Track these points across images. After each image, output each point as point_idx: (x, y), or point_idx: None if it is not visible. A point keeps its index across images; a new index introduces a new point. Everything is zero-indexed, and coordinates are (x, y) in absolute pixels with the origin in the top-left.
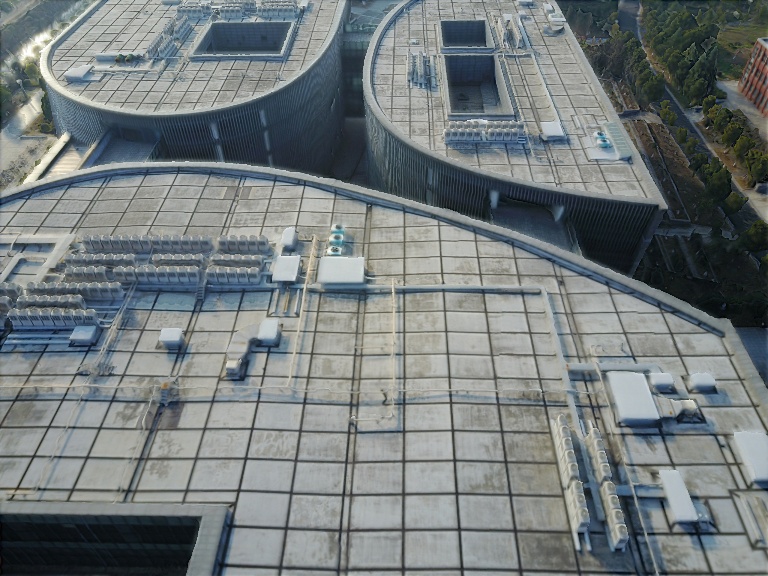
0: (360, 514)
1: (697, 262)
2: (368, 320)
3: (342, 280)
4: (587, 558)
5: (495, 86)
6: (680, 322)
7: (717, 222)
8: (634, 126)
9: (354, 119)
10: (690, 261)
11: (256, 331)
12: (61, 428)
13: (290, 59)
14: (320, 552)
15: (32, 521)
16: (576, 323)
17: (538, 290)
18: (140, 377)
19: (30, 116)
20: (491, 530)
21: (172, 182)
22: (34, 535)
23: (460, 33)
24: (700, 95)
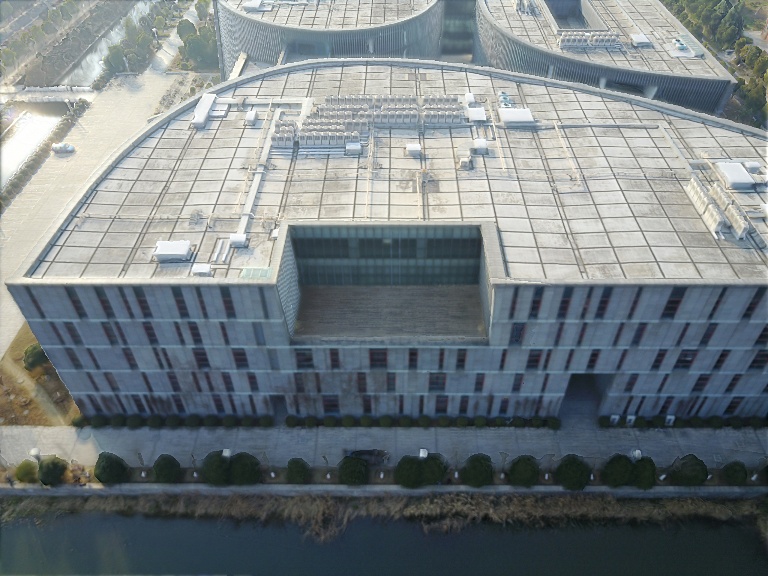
0: (576, 227)
1: None
2: (543, 142)
3: (519, 120)
4: (723, 242)
5: (580, 18)
6: (758, 141)
7: (758, 122)
8: None
9: (448, 57)
10: None
11: (472, 145)
12: (364, 192)
13: None
14: (558, 241)
15: (365, 236)
16: (687, 143)
17: (656, 126)
18: (402, 169)
19: (167, 58)
20: (661, 231)
21: (365, 70)
22: (357, 253)
23: None
24: (731, 40)
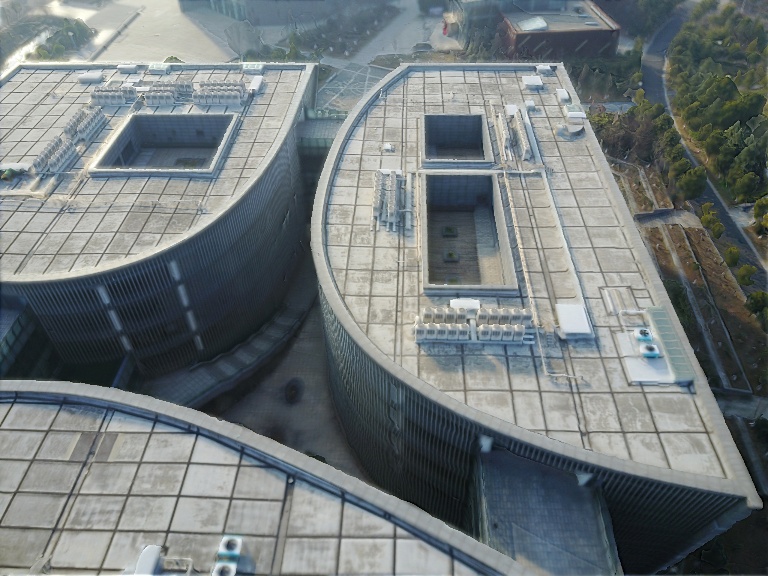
0: None
1: (767, 468)
2: None
3: None
4: None
5: (493, 215)
6: None
7: None
8: (668, 234)
9: None
10: (757, 465)
11: None
12: None
13: (222, 176)
14: None
15: None
16: None
17: None
18: None
19: None
20: None
21: (0, 422)
22: None
23: (450, 129)
24: (749, 192)
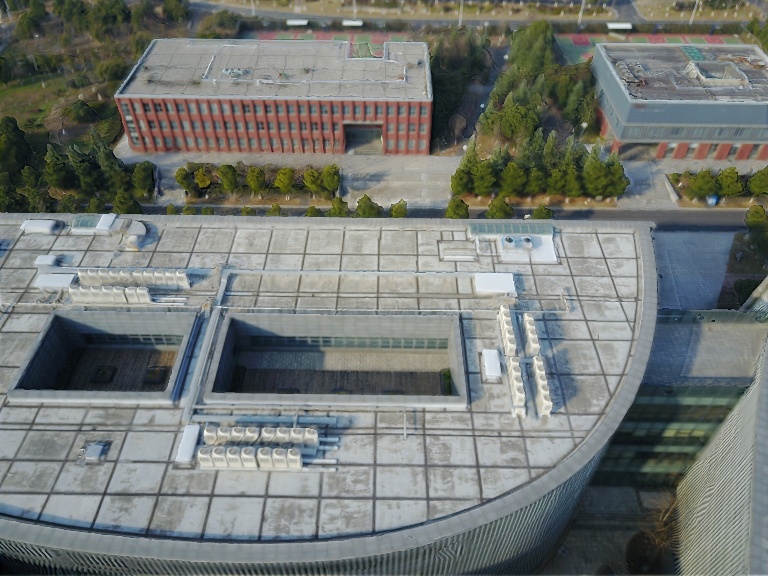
0: None
1: None
2: None
3: None
4: None
5: (266, 344)
6: None
7: None
8: None
9: None
10: None
11: None
12: None
13: None
14: None
15: None
16: None
17: None
18: None
19: None
20: None
21: None
22: None
23: (44, 369)
24: None
